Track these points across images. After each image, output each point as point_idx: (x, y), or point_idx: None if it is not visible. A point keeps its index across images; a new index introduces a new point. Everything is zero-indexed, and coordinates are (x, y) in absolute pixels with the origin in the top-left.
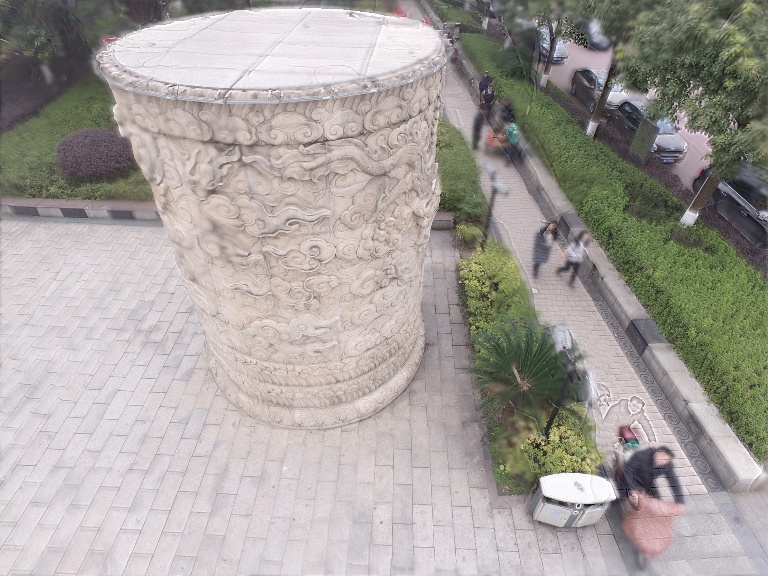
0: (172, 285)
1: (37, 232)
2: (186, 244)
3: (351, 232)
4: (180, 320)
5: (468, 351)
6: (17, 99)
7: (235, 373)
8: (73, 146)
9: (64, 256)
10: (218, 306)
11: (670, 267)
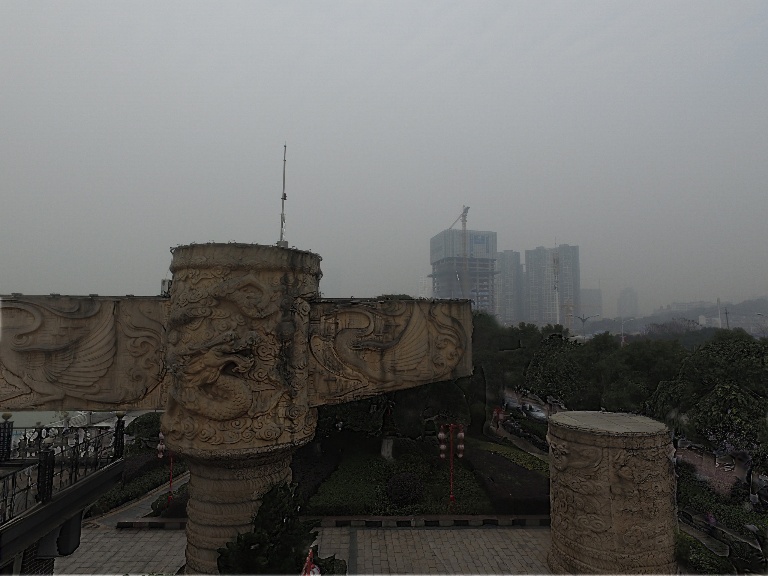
0: (504, 555)
1: (395, 534)
2: (602, 492)
3: (665, 481)
4: (530, 570)
5: (698, 570)
6: (321, 462)
7: (611, 571)
8: (406, 482)
9: (425, 545)
10: (611, 523)
11: (763, 523)
